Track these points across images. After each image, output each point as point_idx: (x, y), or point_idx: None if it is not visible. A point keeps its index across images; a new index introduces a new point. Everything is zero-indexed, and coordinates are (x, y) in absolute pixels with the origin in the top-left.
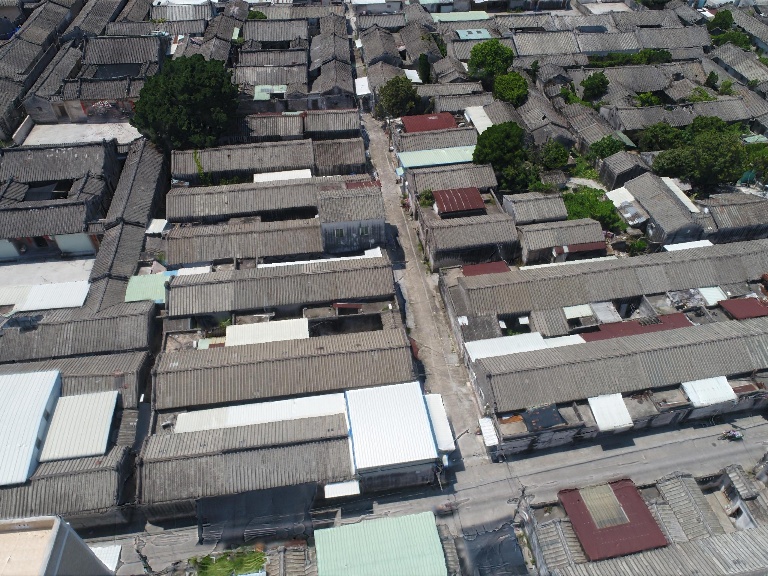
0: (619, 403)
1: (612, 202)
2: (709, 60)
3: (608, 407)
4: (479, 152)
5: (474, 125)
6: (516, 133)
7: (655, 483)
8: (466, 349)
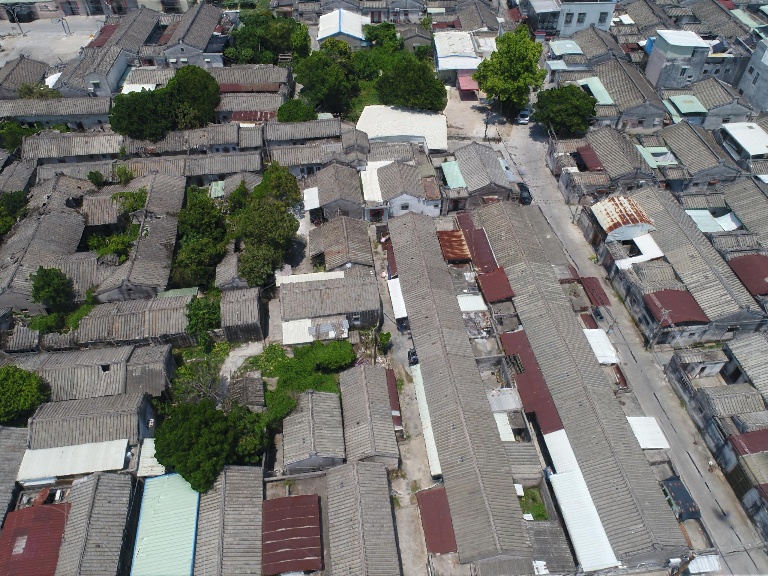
0: (636, 422)
1: (319, 342)
2: (46, 166)
3: (644, 433)
4: (205, 477)
5: (83, 474)
6: (208, 410)
7: (718, 418)
8: (598, 570)
